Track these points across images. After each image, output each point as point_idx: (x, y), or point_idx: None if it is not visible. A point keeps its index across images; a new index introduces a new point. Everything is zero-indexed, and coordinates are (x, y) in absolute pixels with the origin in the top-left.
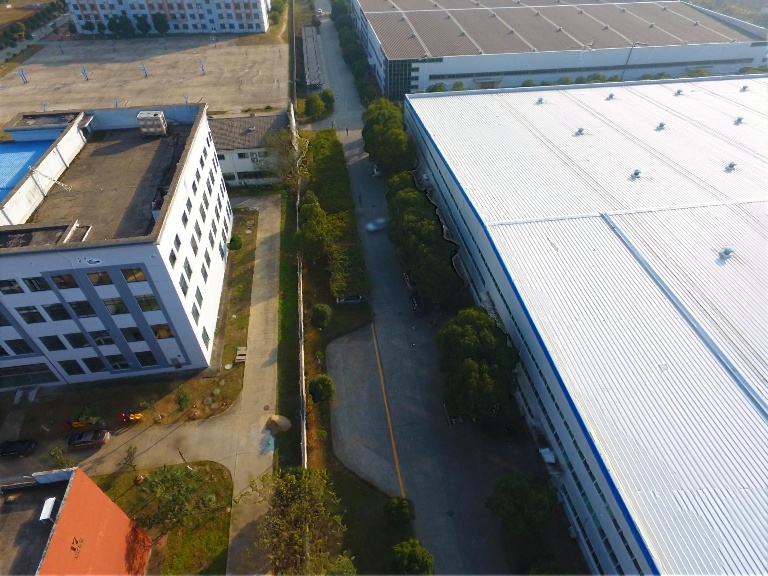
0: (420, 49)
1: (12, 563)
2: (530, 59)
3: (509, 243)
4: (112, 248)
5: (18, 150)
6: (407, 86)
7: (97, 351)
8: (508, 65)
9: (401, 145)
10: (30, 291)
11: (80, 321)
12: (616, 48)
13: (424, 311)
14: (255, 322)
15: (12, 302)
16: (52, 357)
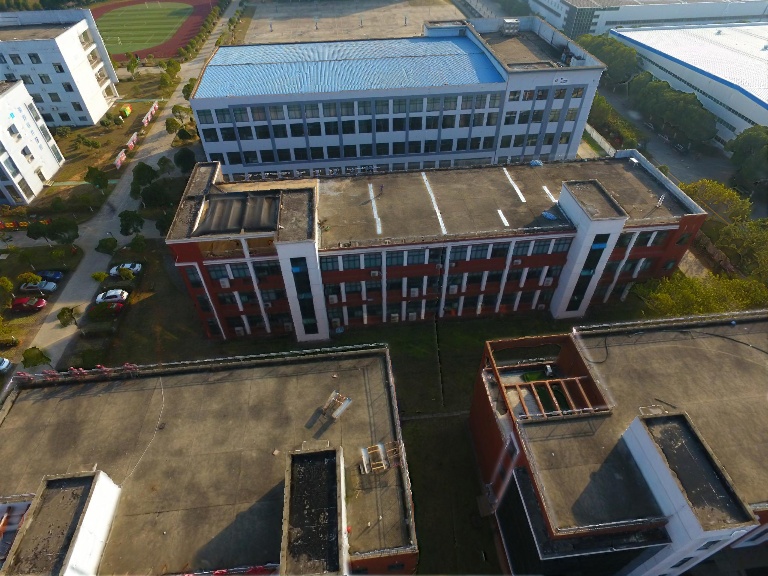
0: (590, 3)
1: (633, 175)
2: (687, 9)
3: (762, 97)
4: (583, 71)
5: (439, 40)
6: (587, 30)
7: (523, 150)
8: (669, 14)
9: (633, 57)
10: (522, 100)
11: (531, 125)
12: (757, 0)
13: (686, 151)
14: (582, 153)
15: (508, 107)
16: (498, 153)
